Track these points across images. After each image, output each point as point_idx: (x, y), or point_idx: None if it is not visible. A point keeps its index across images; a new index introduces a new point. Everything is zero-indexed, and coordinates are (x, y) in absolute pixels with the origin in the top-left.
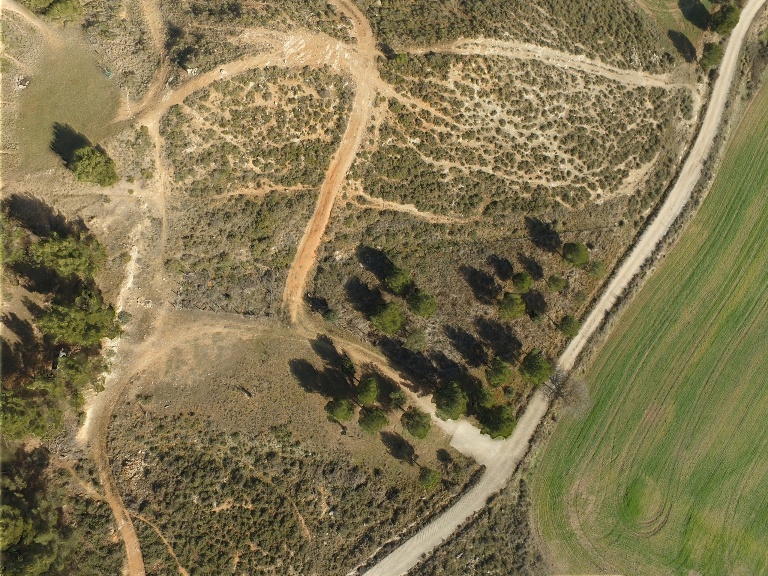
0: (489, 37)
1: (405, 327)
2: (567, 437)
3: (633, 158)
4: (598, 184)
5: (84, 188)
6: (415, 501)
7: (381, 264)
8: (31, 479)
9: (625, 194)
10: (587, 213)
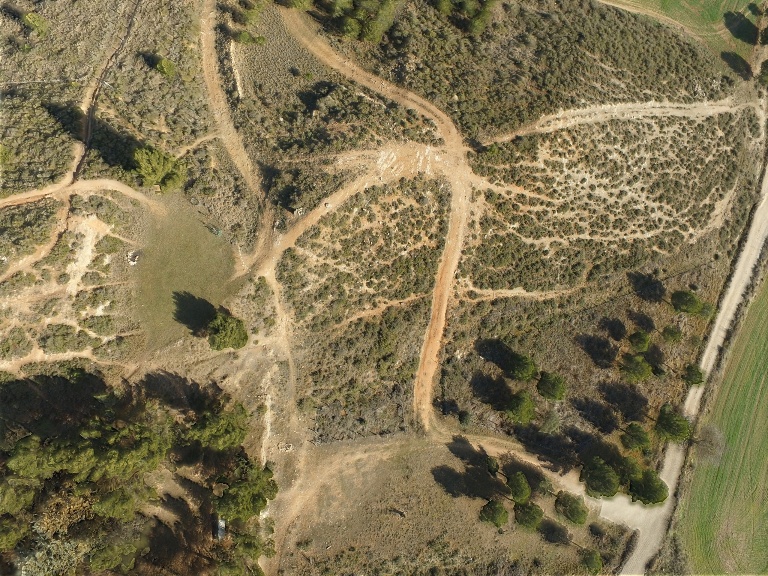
0: (568, 109)
1: (534, 409)
2: (706, 480)
3: (715, 190)
4: (688, 224)
5: (212, 351)
6: None
7: (500, 352)
8: None
9: (715, 228)
10: (684, 255)
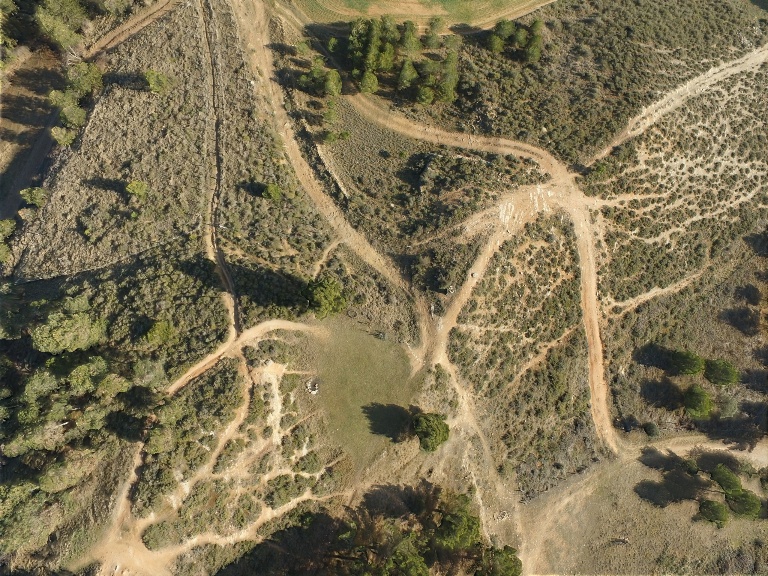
0: (649, 105)
1: None
2: None
3: None
4: None
5: (413, 450)
6: None
7: (656, 354)
8: None
9: None
10: None
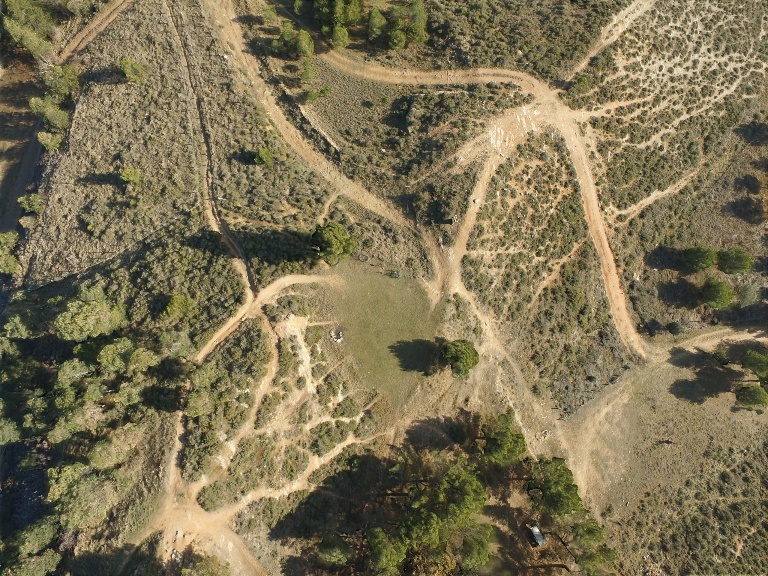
0: (618, 12)
1: None
2: None
3: (764, 20)
4: (760, 61)
5: (446, 382)
6: None
7: (668, 256)
8: None
9: None
10: None
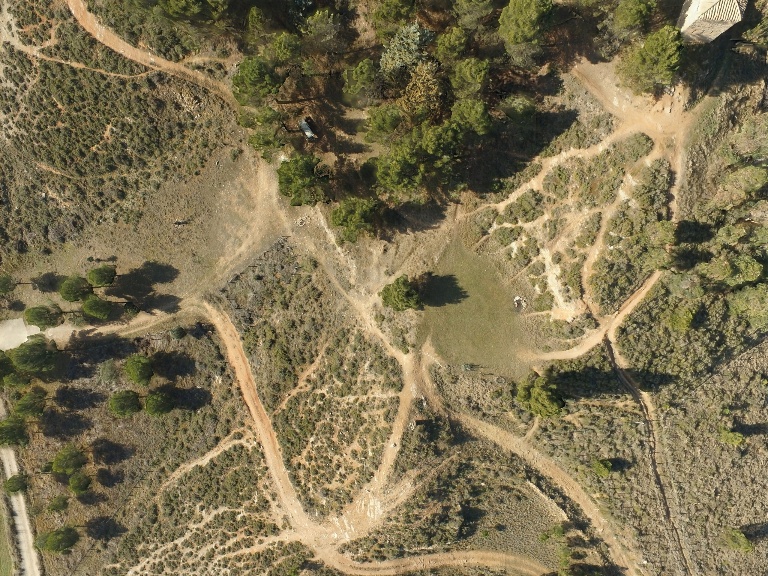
0: None
1: None
2: None
3: None
4: None
5: (408, 267)
6: (3, 257)
7: (187, 401)
8: (231, 33)
9: None
10: (91, 574)
